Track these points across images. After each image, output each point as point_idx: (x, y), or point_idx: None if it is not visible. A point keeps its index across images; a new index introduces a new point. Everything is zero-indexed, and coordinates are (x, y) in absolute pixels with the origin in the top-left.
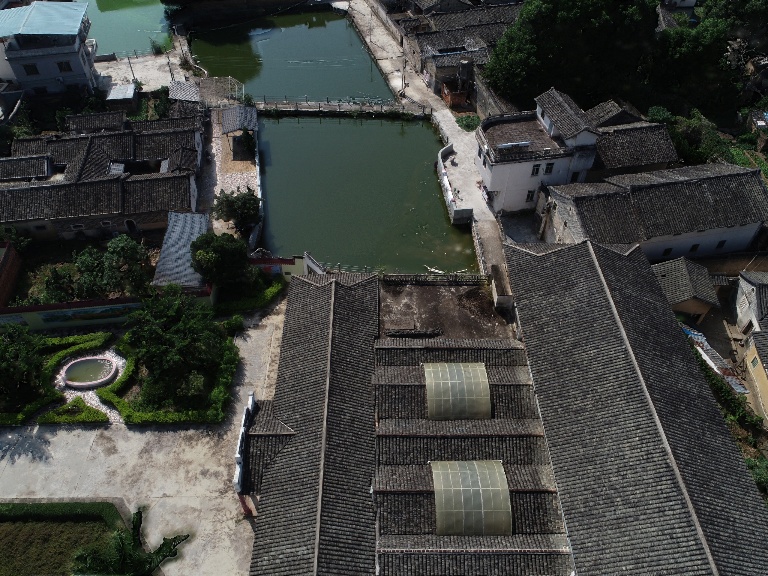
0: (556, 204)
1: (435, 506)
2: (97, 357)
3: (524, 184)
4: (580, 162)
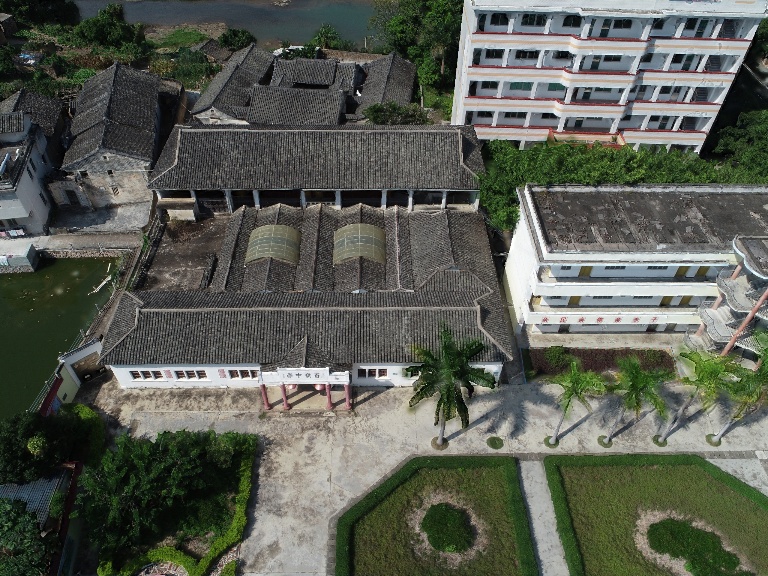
0: (84, 171)
1: (369, 260)
2: None
3: (34, 191)
4: (41, 143)
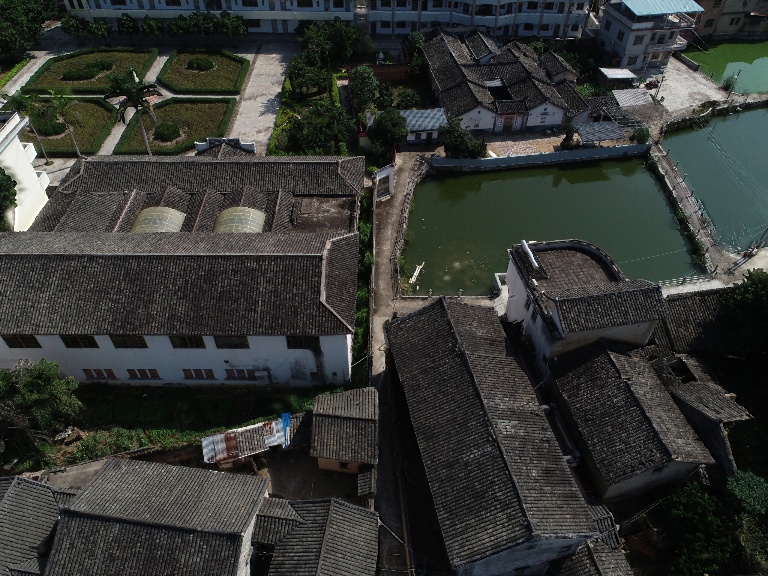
0: None
1: None
2: None
3: None
4: None
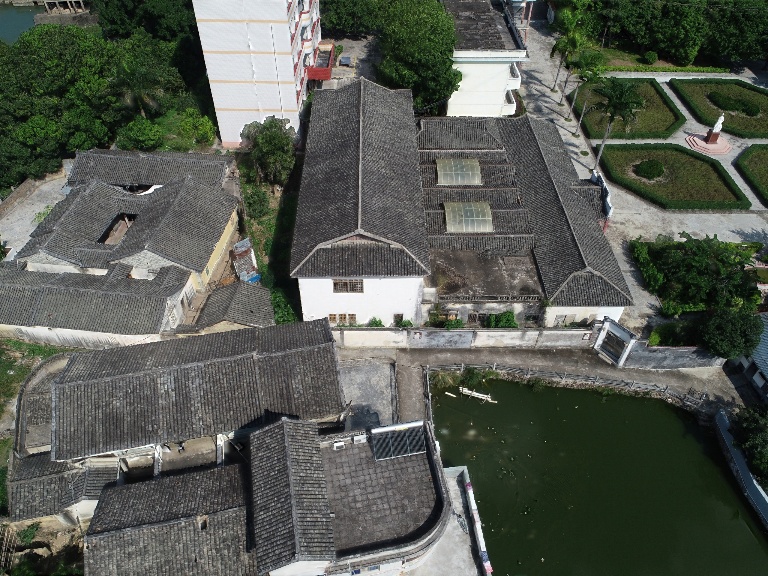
0: None
1: None
2: (766, 284)
3: None
4: None
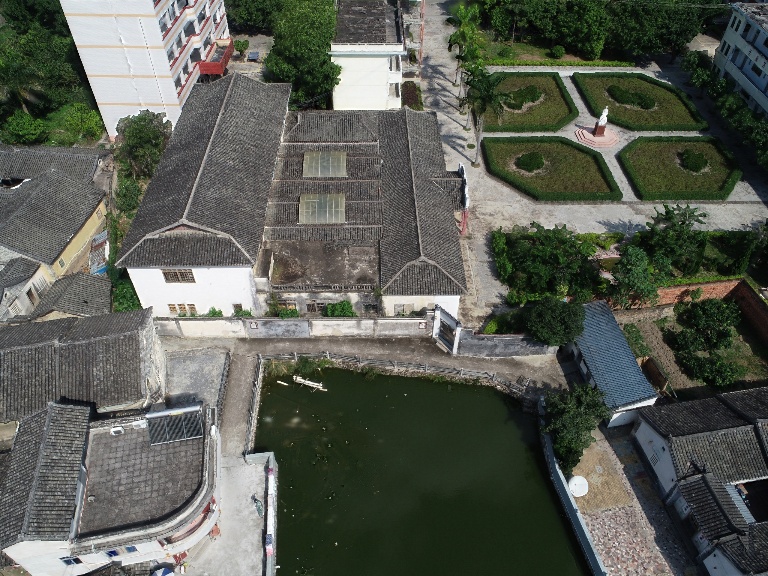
0: None
1: None
2: None
3: None
4: None
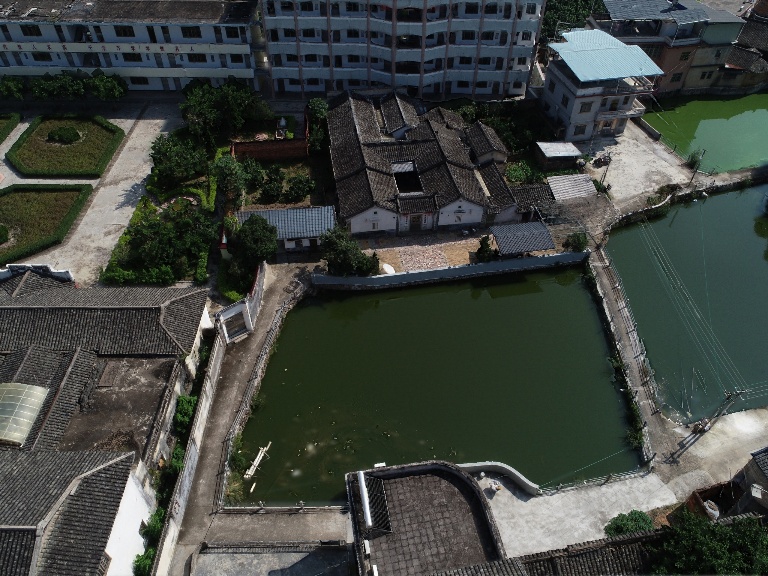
0: None
1: None
2: None
3: None
4: None
